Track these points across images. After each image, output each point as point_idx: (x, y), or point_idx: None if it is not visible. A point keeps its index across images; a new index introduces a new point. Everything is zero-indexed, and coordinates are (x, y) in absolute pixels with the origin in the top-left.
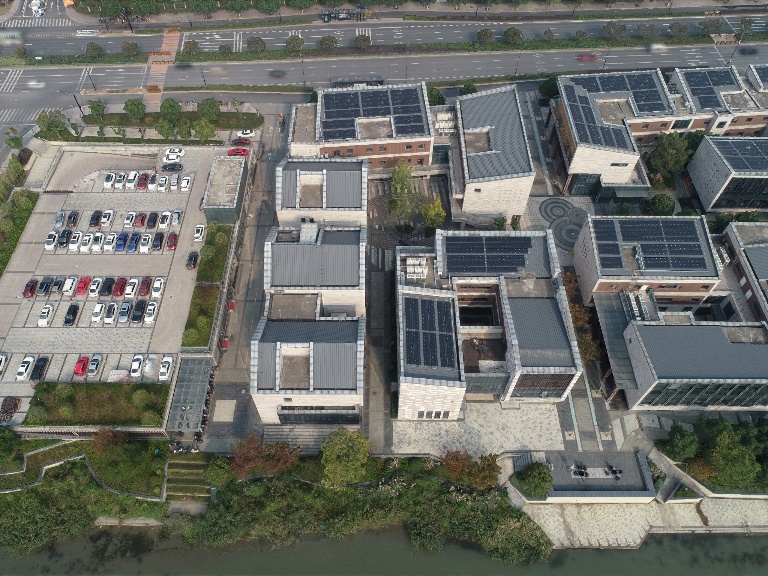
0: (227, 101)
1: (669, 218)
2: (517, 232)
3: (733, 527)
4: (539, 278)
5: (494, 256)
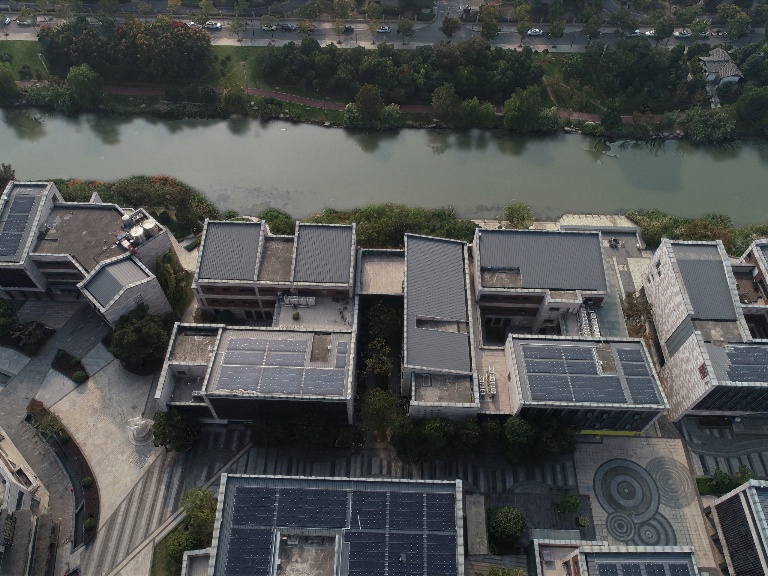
0: None
1: (564, 403)
2: (753, 384)
3: (495, 222)
4: (707, 342)
5: (766, 364)
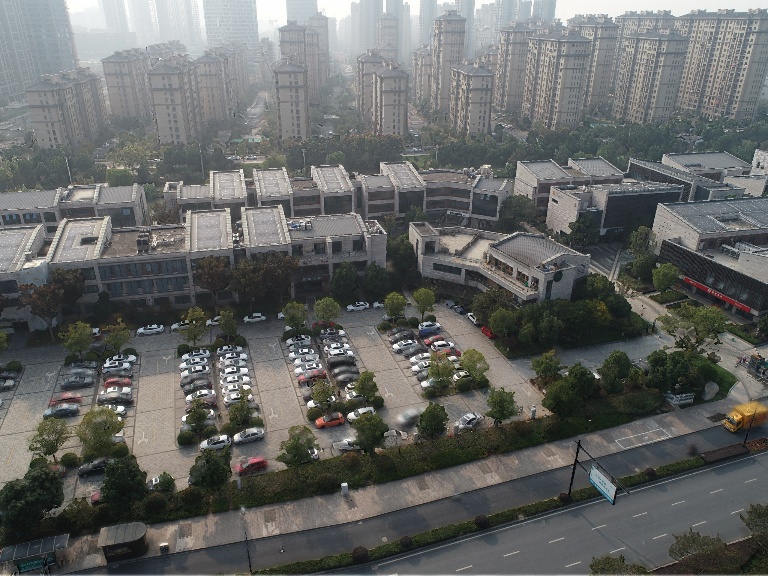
0: None
1: None
2: None
3: None
4: None
5: None
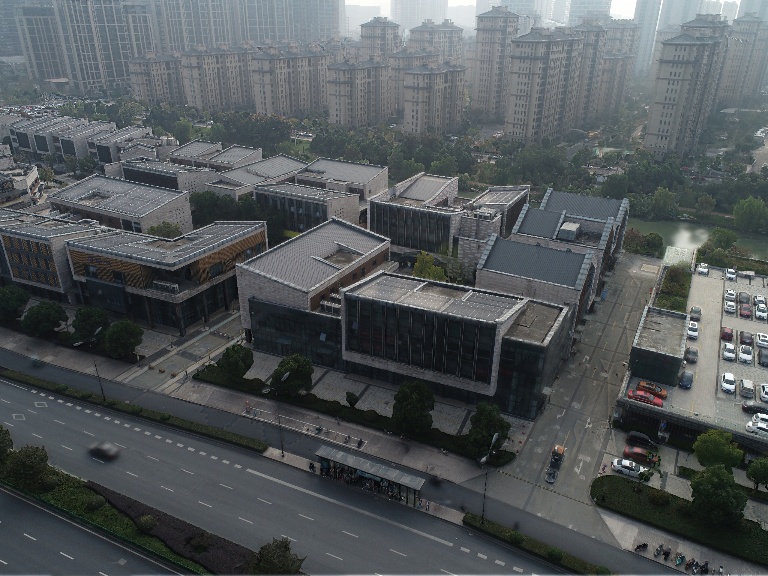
0: (680, 574)
1: None
2: (392, 204)
3: None
4: None
5: None
